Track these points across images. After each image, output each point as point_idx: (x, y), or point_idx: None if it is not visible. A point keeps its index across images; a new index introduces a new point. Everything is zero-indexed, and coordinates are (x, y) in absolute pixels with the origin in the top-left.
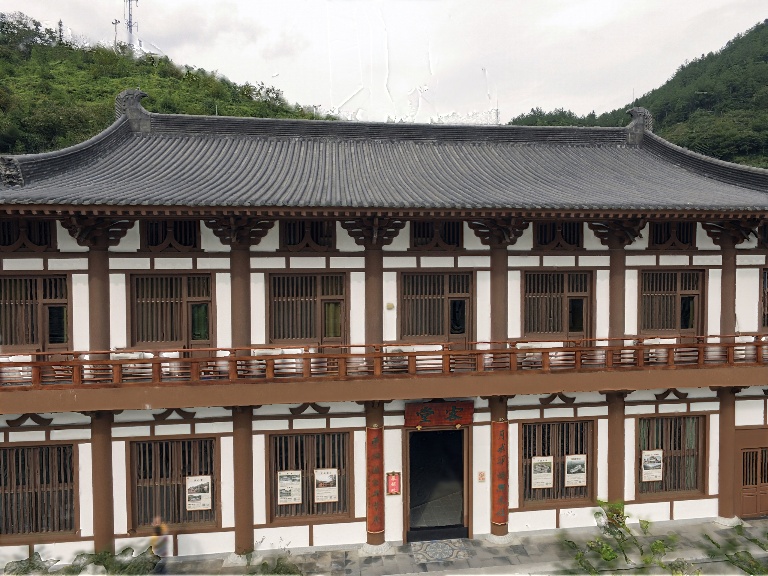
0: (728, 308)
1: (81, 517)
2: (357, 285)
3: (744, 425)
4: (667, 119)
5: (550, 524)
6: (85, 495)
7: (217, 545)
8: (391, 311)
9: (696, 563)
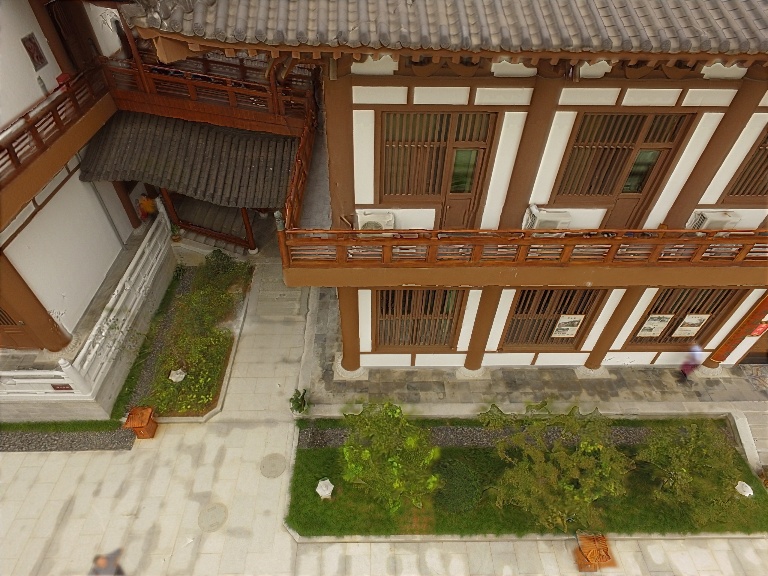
0: None
1: (460, 340)
2: None
3: None
4: None
5: None
6: (467, 326)
7: (570, 360)
8: None
9: None
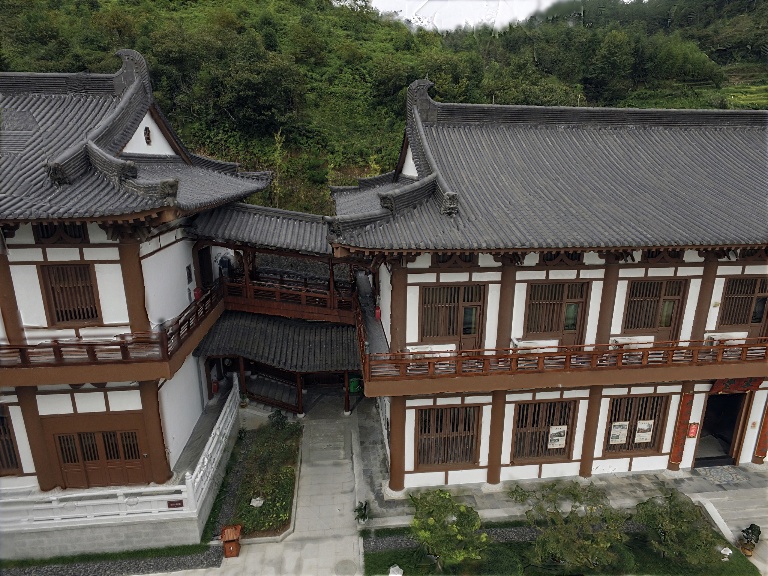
0: None
1: (481, 454)
2: (694, 289)
3: None
4: (728, 8)
5: None
6: (485, 440)
7: (568, 471)
8: (715, 308)
9: None
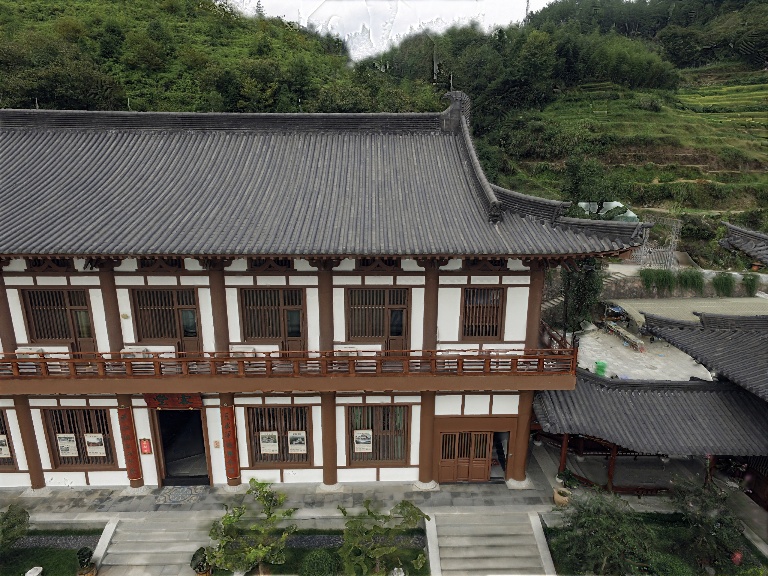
0: (428, 322)
1: None
2: (96, 299)
3: (443, 414)
4: (725, 4)
5: (276, 479)
6: None
7: (18, 481)
8: (127, 320)
9: (364, 518)
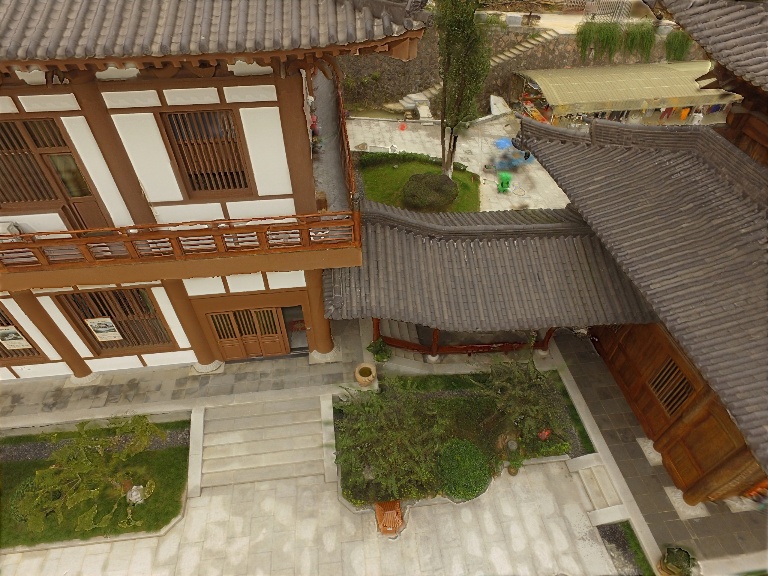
0: (117, 174)
1: None
2: None
3: (200, 295)
4: None
5: (8, 376)
6: None
7: None
8: None
9: (117, 418)
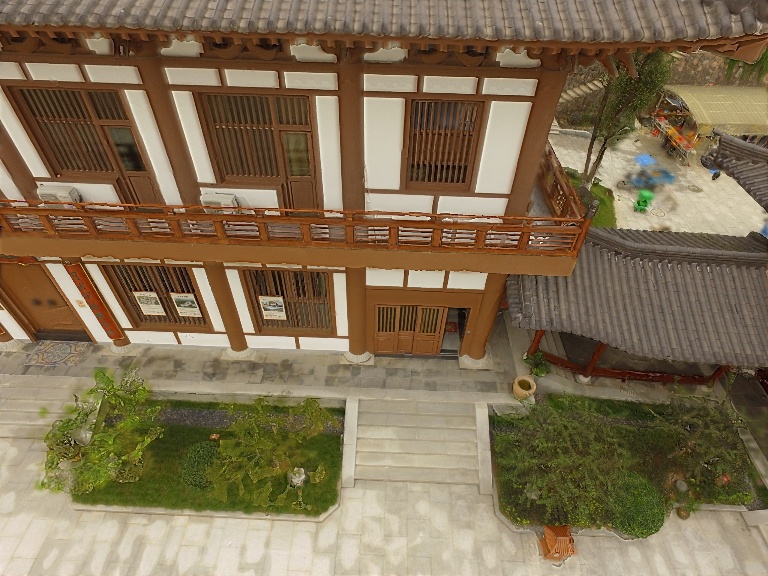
0: (348, 158)
1: None
2: None
3: (377, 285)
4: None
5: (172, 341)
6: None
7: None
8: None
9: (273, 396)
